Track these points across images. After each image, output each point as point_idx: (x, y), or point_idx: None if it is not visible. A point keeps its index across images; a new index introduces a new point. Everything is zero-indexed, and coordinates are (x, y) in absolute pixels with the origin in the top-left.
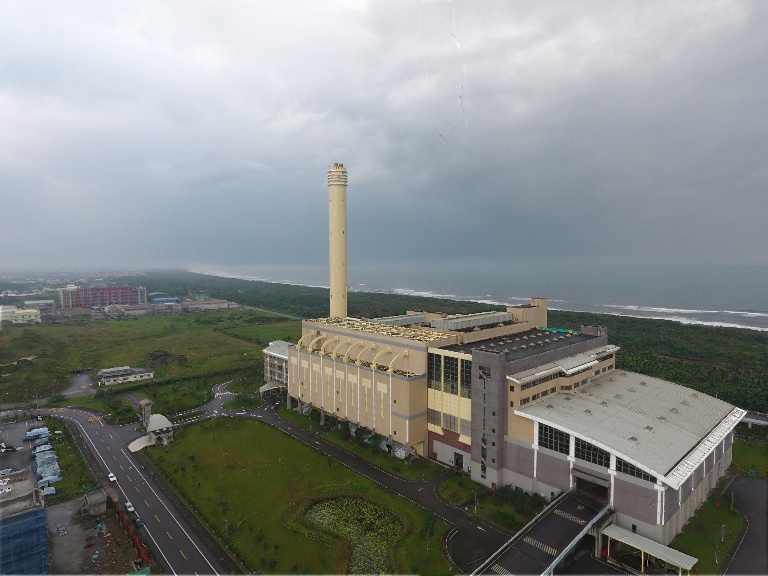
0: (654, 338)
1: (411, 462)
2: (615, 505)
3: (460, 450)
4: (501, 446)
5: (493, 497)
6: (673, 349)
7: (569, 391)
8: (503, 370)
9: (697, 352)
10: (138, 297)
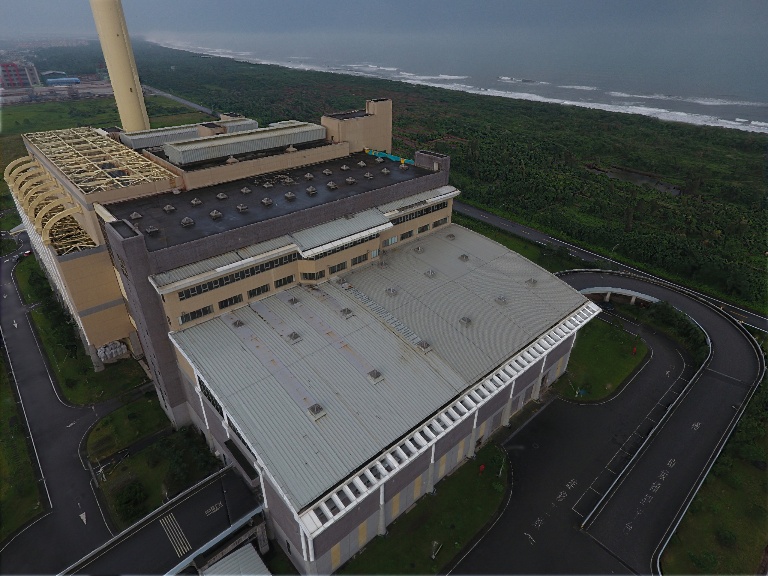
0: (610, 143)
1: (105, 368)
2: (269, 508)
3: None
4: (172, 376)
5: (146, 452)
6: (626, 159)
7: (316, 281)
8: (145, 266)
9: (652, 164)
10: (27, 77)
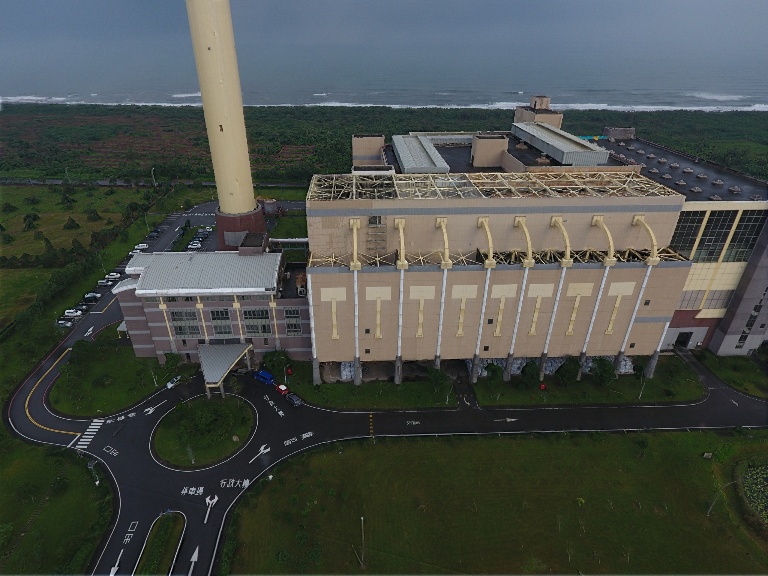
0: None
1: None
2: None
3: (691, 328)
4: None
5: None
6: None
7: None
8: None
9: None
10: None
